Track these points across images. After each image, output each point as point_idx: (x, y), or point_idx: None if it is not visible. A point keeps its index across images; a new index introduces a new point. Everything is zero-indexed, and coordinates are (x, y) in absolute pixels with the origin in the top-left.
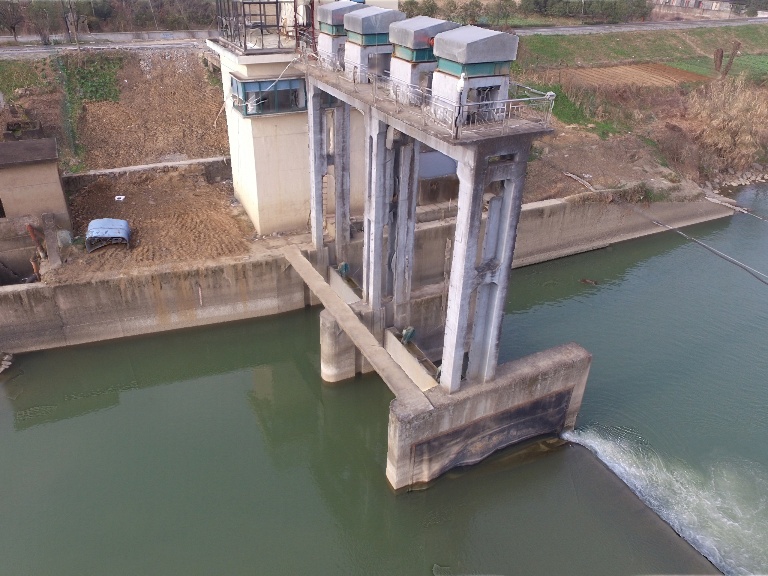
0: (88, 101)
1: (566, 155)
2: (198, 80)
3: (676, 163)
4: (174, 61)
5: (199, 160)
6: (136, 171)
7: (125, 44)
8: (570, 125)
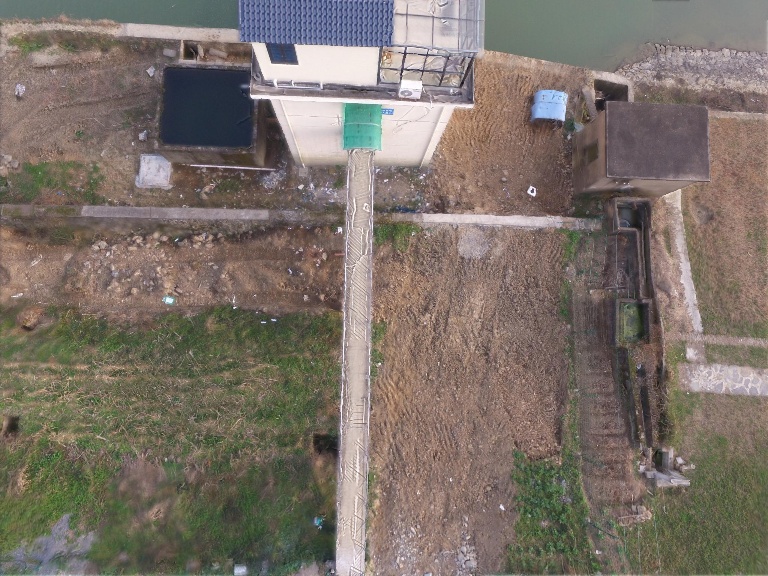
0: (555, 457)
1: None
2: (392, 492)
3: None
4: (419, 567)
5: (452, 217)
6: None
7: None
8: None
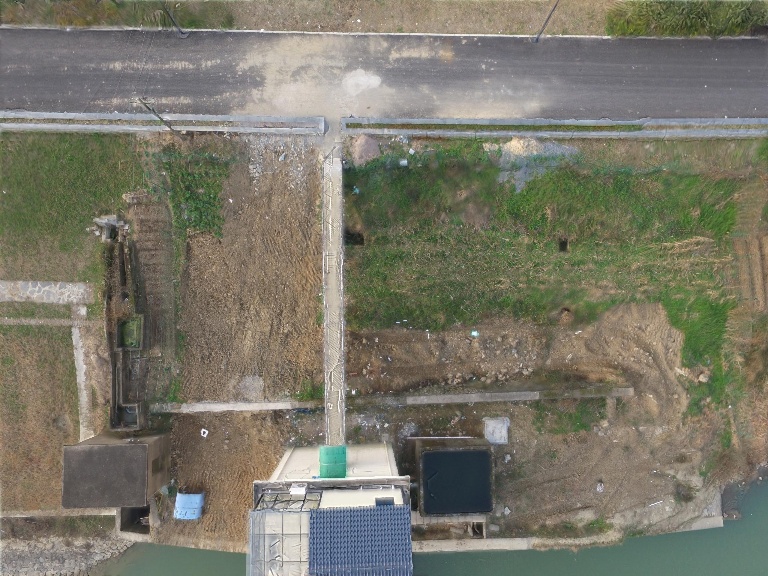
0: (192, 234)
1: (615, 440)
2: (308, 209)
3: (720, 472)
4: (288, 164)
5: (268, 407)
6: (217, 411)
7: (242, 69)
8: (681, 368)
